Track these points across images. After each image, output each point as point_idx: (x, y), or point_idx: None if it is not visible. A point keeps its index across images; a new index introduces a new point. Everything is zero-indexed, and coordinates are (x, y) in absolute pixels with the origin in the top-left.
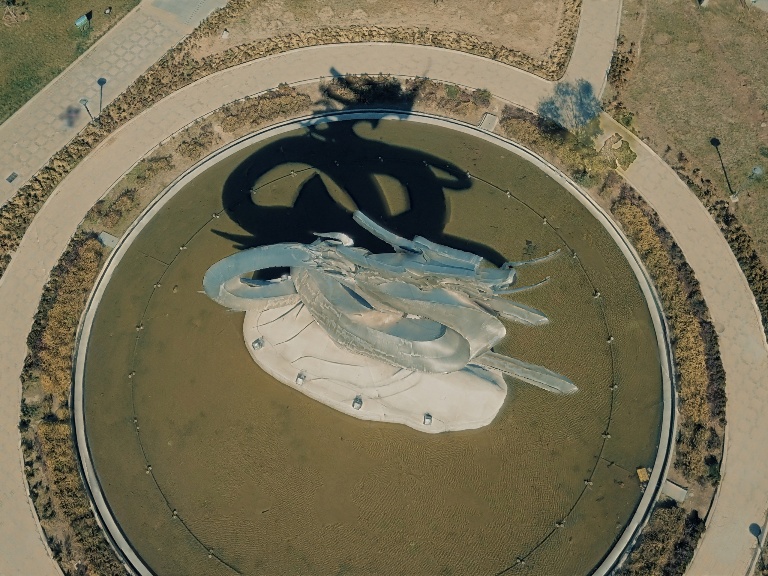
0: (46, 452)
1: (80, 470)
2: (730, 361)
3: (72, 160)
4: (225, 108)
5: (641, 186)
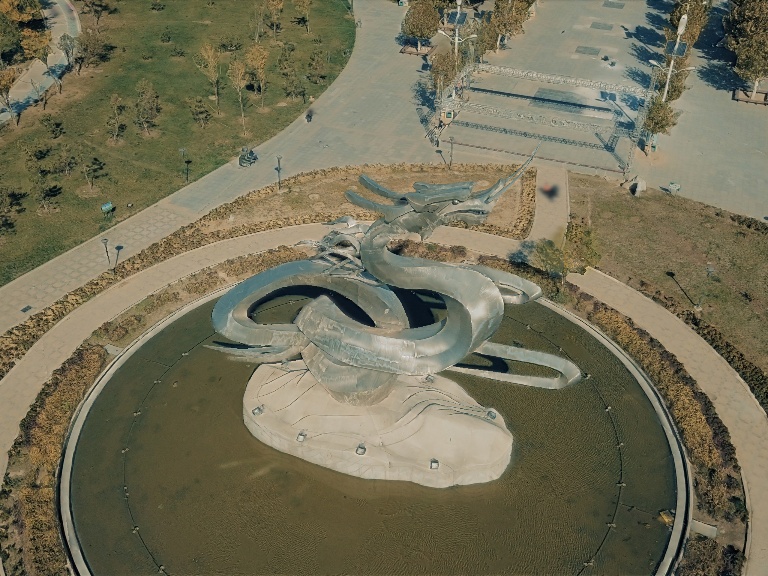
0: (25, 513)
1: (60, 531)
2: (729, 421)
3: (85, 295)
4: (230, 260)
5: (611, 302)
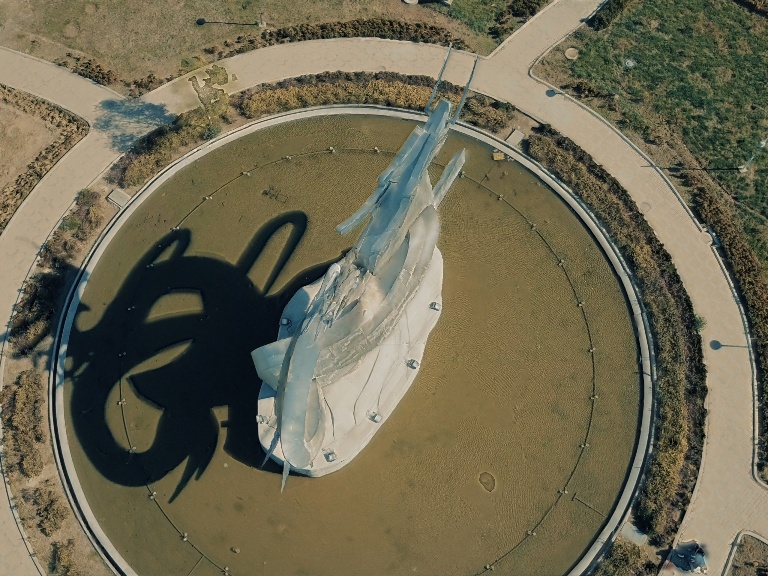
0: None
1: None
2: (412, 70)
3: None
4: (8, 470)
5: (231, 89)
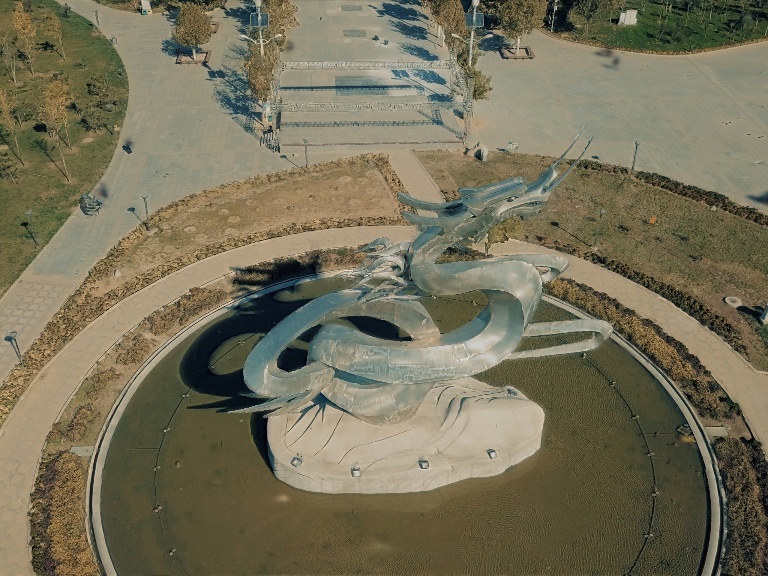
0: None
1: None
2: (677, 336)
3: (8, 402)
4: (148, 318)
5: None
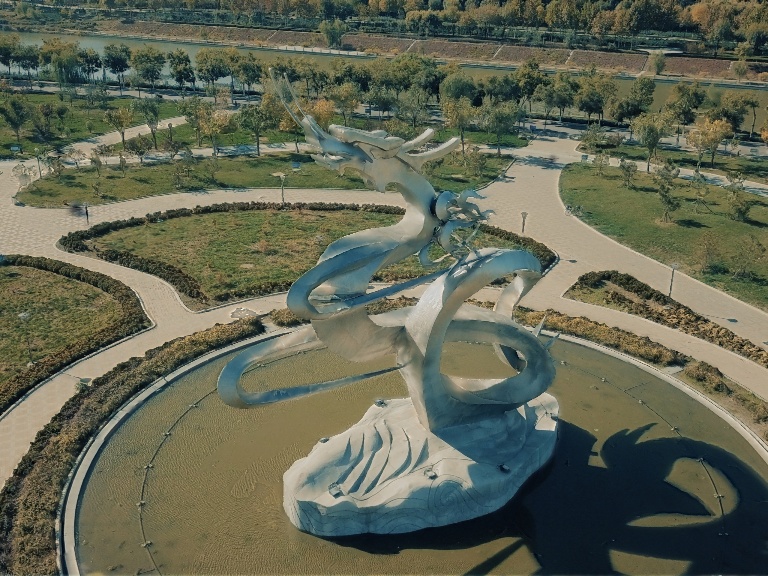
0: None
1: None
2: None
3: None
4: None
5: None
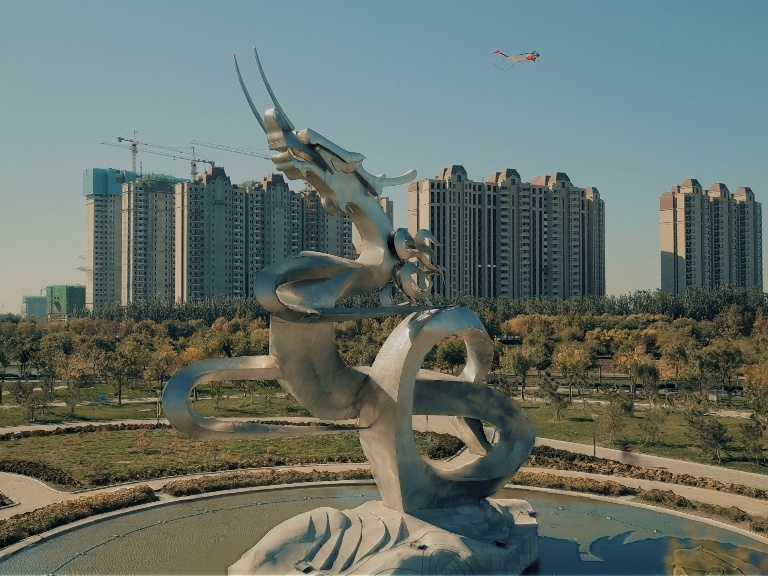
0: None
1: None
2: None
3: (734, 489)
4: None
5: None
